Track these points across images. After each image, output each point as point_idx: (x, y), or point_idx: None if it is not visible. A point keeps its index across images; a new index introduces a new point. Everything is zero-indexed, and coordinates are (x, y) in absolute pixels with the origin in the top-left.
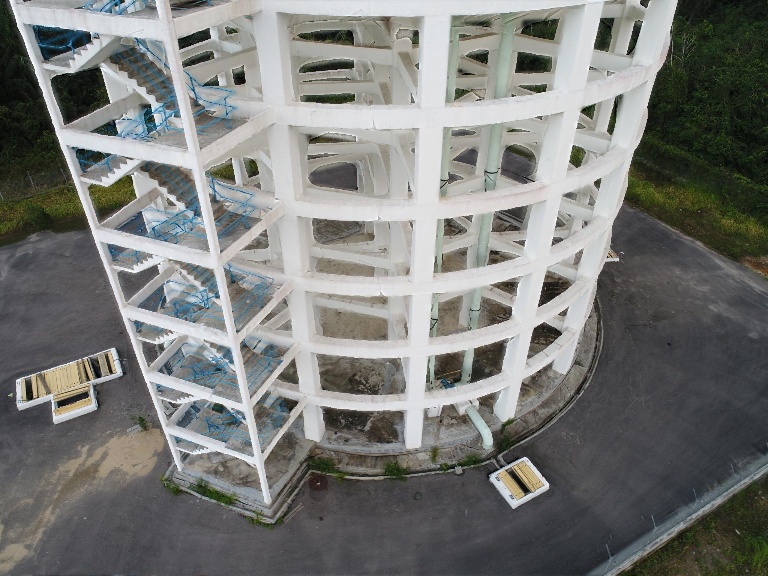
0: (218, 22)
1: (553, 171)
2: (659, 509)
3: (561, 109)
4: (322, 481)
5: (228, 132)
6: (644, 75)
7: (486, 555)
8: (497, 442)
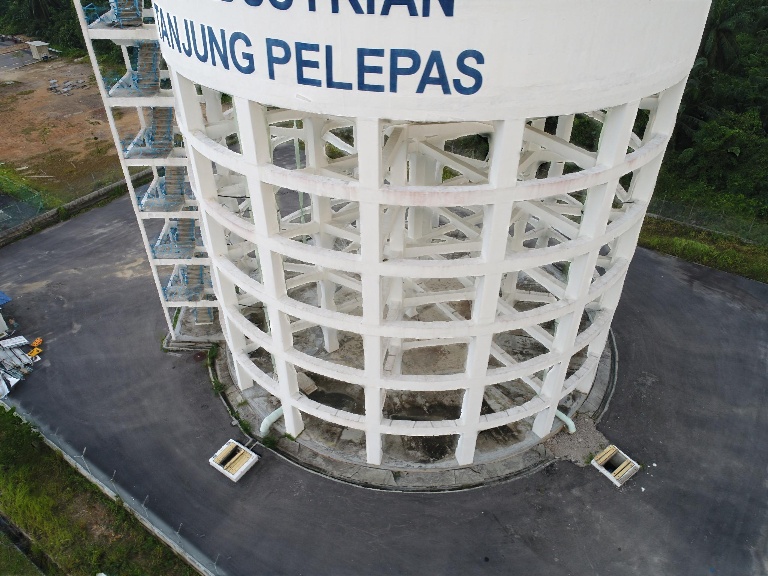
0: (123, 38)
1: (255, 223)
2: (242, 570)
3: (243, 172)
4: (201, 357)
5: (134, 97)
6: (343, 192)
7: (166, 457)
8: (269, 437)
